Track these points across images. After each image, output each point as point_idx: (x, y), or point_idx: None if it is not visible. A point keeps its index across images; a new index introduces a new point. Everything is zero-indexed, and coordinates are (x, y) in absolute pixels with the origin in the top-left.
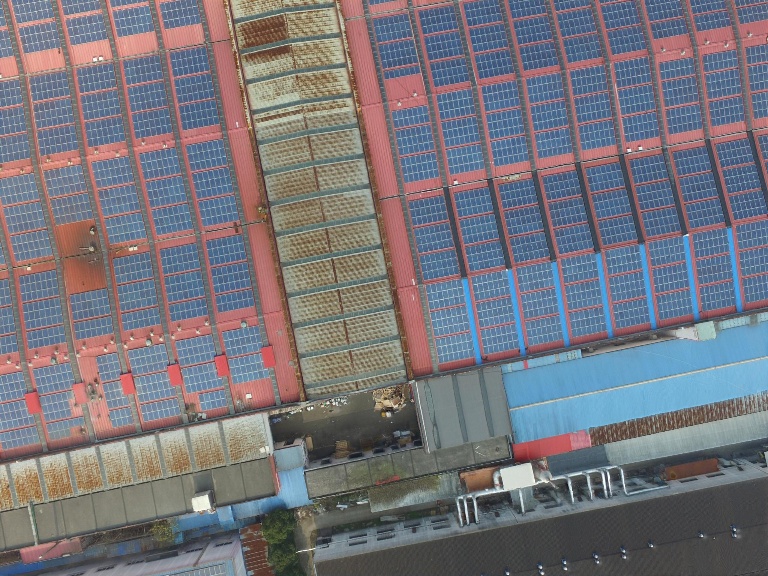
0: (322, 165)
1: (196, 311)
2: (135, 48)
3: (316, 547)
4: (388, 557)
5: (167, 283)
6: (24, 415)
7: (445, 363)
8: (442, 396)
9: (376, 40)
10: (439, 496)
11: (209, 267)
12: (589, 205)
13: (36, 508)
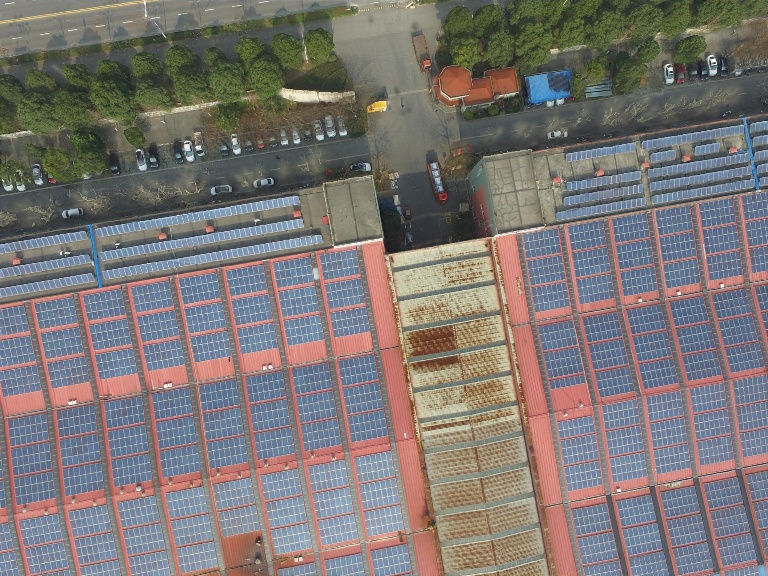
0: (488, 476)
1: None
2: (304, 356)
3: None
4: None
5: None
6: None
7: None
8: None
9: (541, 348)
10: None
11: None
12: (751, 514)
13: None
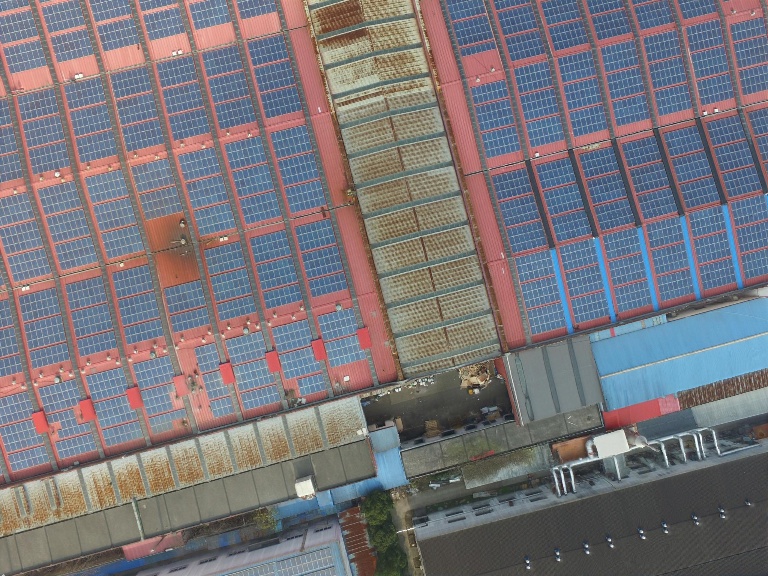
0: (405, 145)
1: (290, 297)
2: (213, 40)
3: (415, 526)
4: (489, 531)
5: (259, 271)
6: (126, 411)
7: (538, 334)
8: (533, 368)
9: (450, 18)
10: (532, 469)
11: (300, 253)
12: (670, 169)
13: (139, 504)
